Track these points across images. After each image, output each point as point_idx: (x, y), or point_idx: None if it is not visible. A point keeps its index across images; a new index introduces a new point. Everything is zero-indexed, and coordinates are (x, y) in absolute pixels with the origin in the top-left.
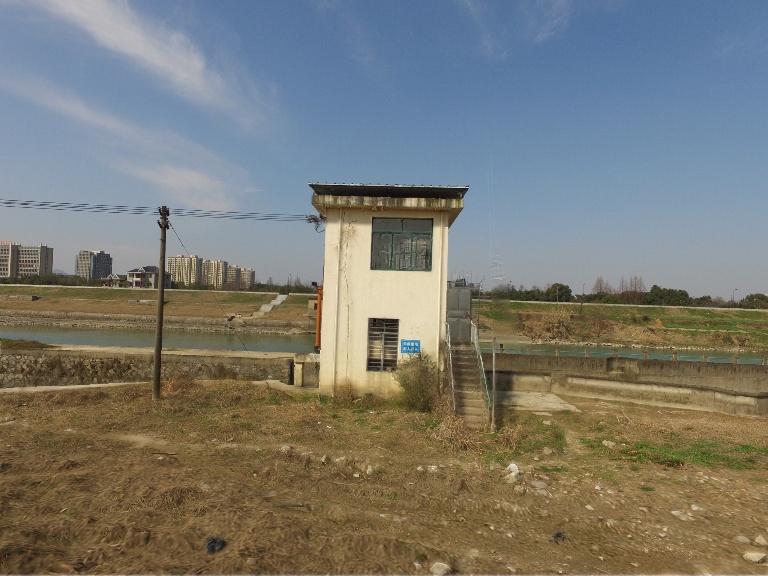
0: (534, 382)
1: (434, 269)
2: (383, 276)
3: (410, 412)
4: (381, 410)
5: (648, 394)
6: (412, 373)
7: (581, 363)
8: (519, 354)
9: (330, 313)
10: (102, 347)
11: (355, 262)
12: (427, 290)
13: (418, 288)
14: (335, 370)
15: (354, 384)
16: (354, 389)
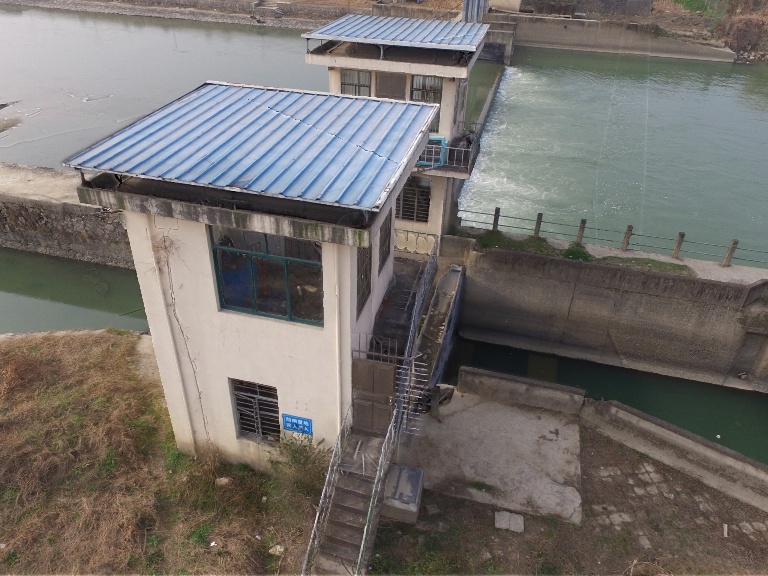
0: (555, 399)
1: (327, 328)
2: (241, 324)
3: (284, 527)
4: (239, 524)
5: (734, 473)
6: (289, 476)
7: (700, 290)
8: (594, 264)
9: (168, 361)
10: (9, 173)
11: (191, 296)
12: (317, 357)
13: (302, 352)
14: (193, 430)
15: (222, 450)
16: (224, 454)
